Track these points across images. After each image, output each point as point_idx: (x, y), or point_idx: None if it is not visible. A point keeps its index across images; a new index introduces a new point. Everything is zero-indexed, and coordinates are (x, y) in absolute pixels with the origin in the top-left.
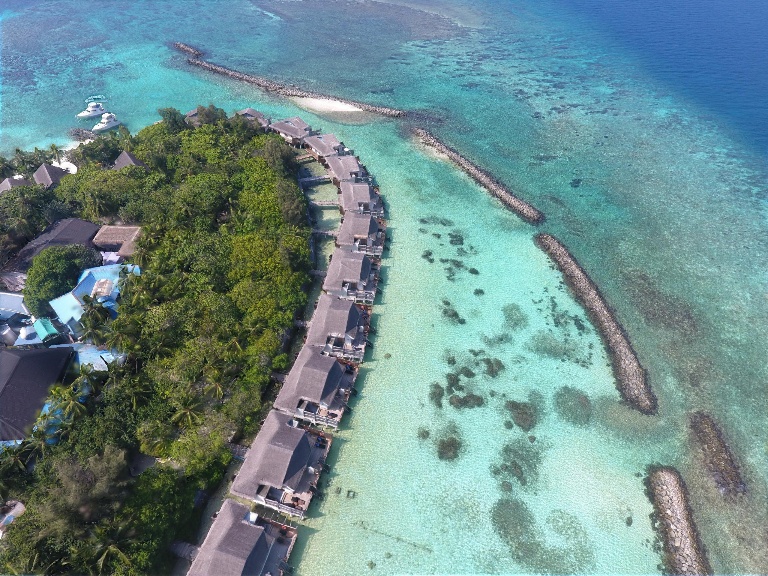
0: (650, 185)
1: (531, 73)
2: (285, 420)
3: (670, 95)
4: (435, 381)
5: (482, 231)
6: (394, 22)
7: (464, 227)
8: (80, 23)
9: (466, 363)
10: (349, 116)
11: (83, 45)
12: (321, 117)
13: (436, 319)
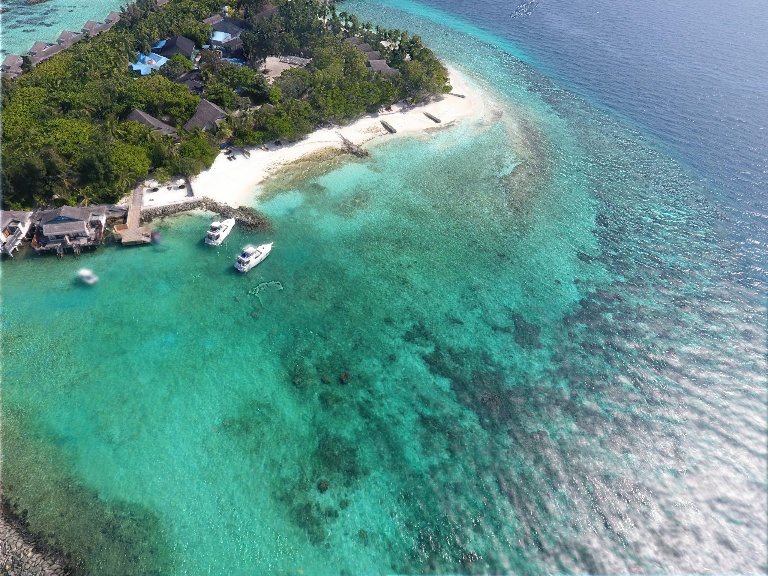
0: None
1: None
2: (65, 42)
3: None
4: None
5: None
6: None
7: None
8: None
9: None
10: None
11: None
12: None
13: None
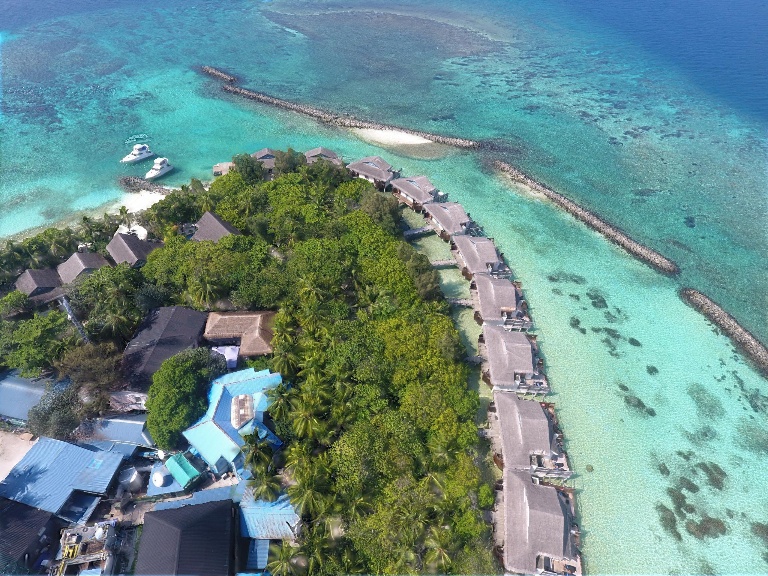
0: (766, 221)
1: (586, 92)
2: None
3: (733, 113)
4: (658, 501)
5: (620, 288)
6: (423, 37)
7: (599, 284)
8: (89, 45)
9: (681, 471)
10: (421, 149)
11: (101, 72)
12: (391, 152)
13: (622, 411)
